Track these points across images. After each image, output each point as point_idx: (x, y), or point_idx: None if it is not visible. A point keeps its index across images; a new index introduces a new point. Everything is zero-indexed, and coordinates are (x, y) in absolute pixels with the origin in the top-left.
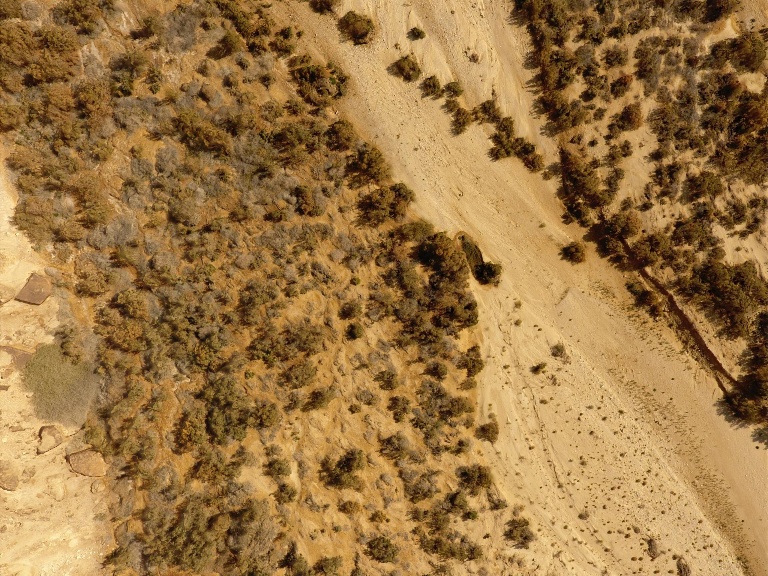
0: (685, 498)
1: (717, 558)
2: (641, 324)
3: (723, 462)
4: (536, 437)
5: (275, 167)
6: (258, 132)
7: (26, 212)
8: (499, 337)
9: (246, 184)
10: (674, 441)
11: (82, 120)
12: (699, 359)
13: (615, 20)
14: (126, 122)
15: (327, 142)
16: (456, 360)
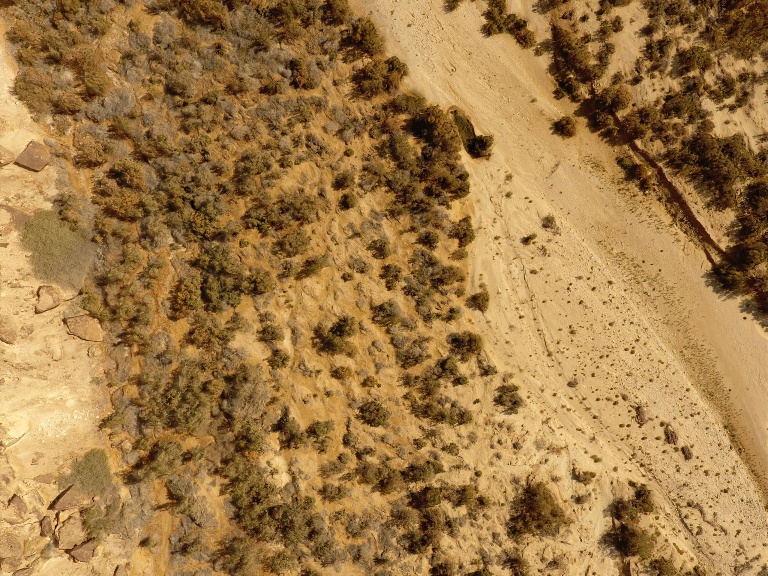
0: (673, 367)
1: (704, 426)
2: (631, 197)
3: (711, 332)
4: (526, 307)
5: (271, 41)
6: (254, 7)
7: (26, 81)
8: (490, 209)
9: (242, 58)
10: (662, 312)
11: None
12: (688, 231)
13: None
14: None
15: (322, 16)
16: (448, 229)
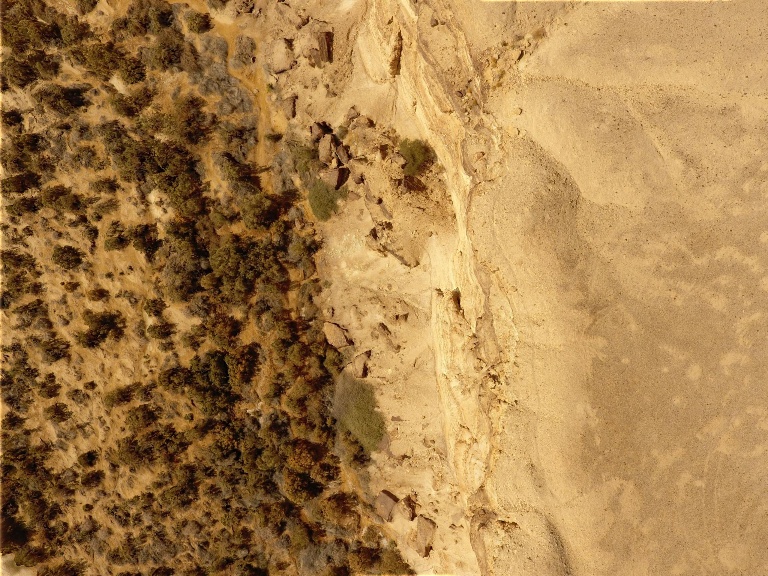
0: None
1: None
2: None
3: None
4: None
5: None
6: None
7: None
8: None
9: None
10: None
11: None
12: None
13: None
14: None
15: None
16: None
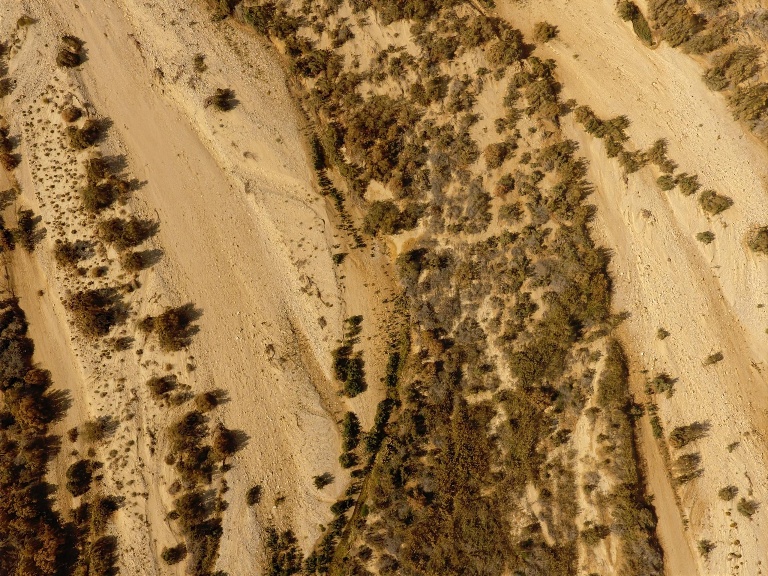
0: None
1: None
2: None
3: None
4: None
5: None
6: None
7: None
8: None
9: None
10: None
11: None
12: None
13: (511, 250)
14: None
15: None
16: None
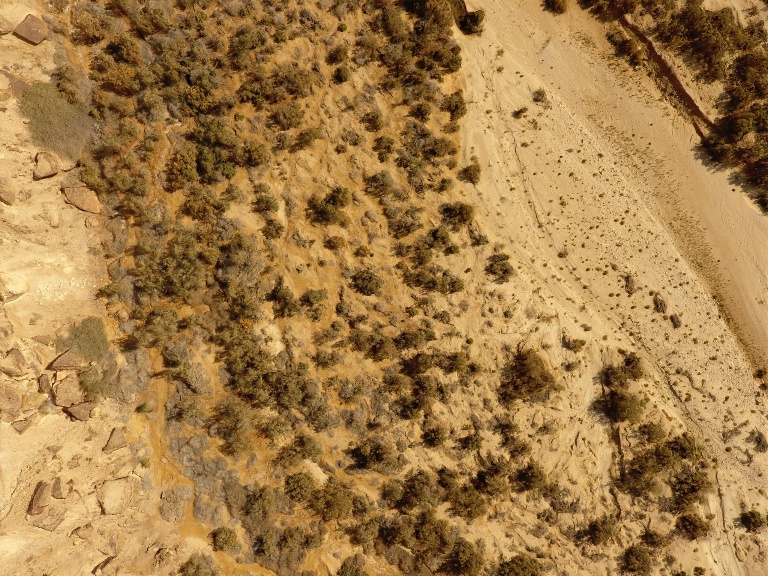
0: (662, 238)
1: (693, 295)
2: (621, 72)
3: (700, 204)
4: (517, 179)
5: None
6: None
7: None
8: (482, 84)
9: None
10: (652, 184)
11: None
12: (677, 105)
13: None
14: None
15: None
16: (439, 102)
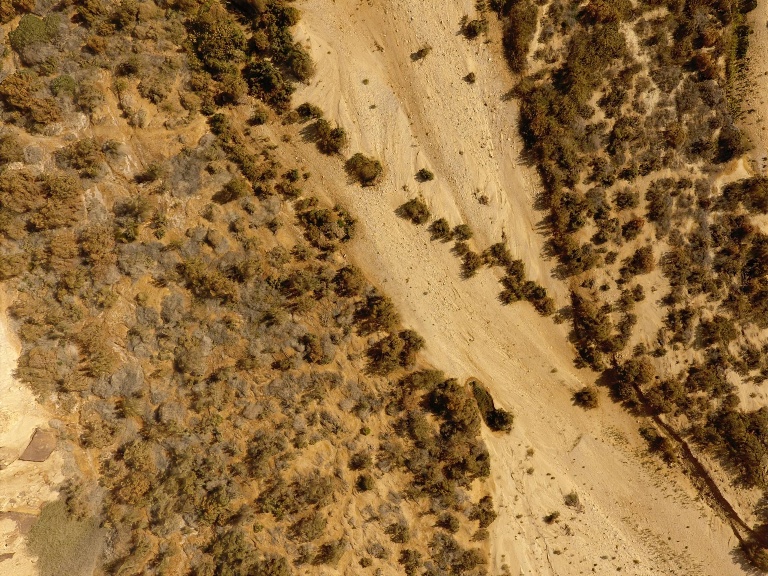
0: None
1: None
2: (655, 471)
3: None
4: None
5: (283, 314)
6: (265, 278)
7: (29, 366)
8: (511, 486)
9: (253, 331)
10: None
11: (86, 268)
12: (714, 506)
13: (626, 161)
14: (131, 271)
15: (335, 288)
16: (468, 512)
